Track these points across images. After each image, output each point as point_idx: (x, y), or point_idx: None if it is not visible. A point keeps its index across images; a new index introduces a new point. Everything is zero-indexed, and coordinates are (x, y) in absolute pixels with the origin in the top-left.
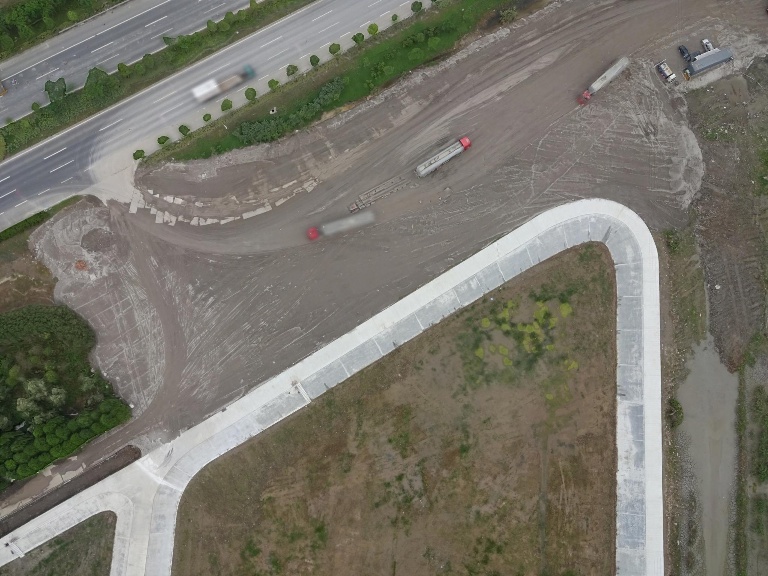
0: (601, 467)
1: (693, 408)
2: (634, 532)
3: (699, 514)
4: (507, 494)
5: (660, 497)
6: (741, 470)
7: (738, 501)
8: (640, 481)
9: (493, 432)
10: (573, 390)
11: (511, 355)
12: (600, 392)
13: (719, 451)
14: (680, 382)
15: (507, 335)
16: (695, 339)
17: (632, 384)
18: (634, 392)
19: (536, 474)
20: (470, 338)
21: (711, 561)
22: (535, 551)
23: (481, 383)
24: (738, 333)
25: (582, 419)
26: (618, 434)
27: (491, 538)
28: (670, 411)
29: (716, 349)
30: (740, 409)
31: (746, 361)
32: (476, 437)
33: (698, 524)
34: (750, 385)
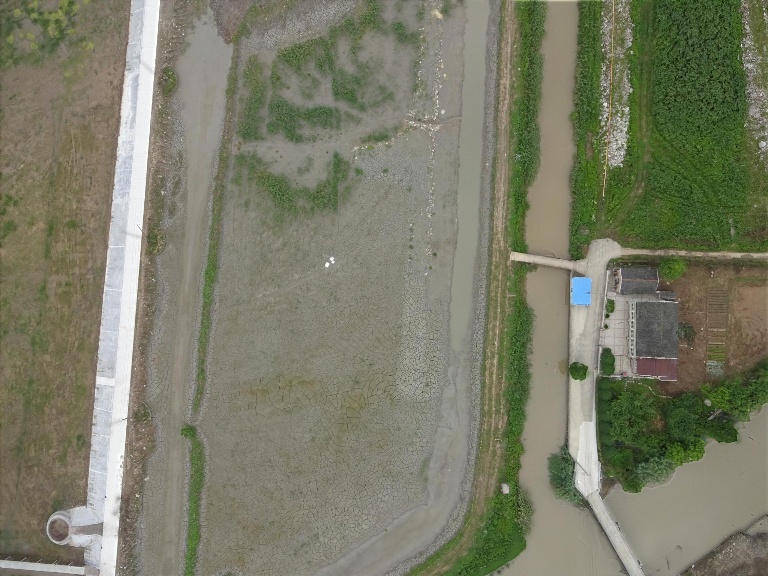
0: (106, 133)
1: (189, 77)
2: (124, 184)
3: (185, 169)
4: (25, 158)
5: (146, 153)
6: (225, 129)
7: (219, 156)
8: (131, 140)
9: (17, 107)
10: (88, 68)
11: (37, 40)
12: (111, 69)
13: (209, 114)
14: (179, 54)
15: (35, 23)
16: (196, 15)
17: (135, 58)
18: (135, 64)
19: (51, 141)
20: (3, 28)
21: (192, 209)
22: (45, 204)
23: (10, 66)
24: (236, 6)
25: (94, 93)
26: (123, 104)
27: (9, 194)
28: (161, 78)
29: (214, 22)
30: (230, 75)
31: (240, 32)
32: (3, 112)
33: (183, 178)
34: (245, 55)
